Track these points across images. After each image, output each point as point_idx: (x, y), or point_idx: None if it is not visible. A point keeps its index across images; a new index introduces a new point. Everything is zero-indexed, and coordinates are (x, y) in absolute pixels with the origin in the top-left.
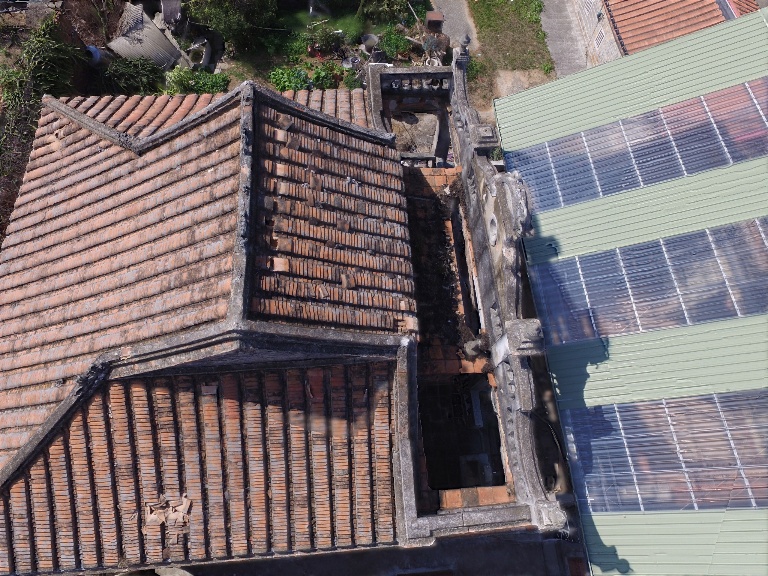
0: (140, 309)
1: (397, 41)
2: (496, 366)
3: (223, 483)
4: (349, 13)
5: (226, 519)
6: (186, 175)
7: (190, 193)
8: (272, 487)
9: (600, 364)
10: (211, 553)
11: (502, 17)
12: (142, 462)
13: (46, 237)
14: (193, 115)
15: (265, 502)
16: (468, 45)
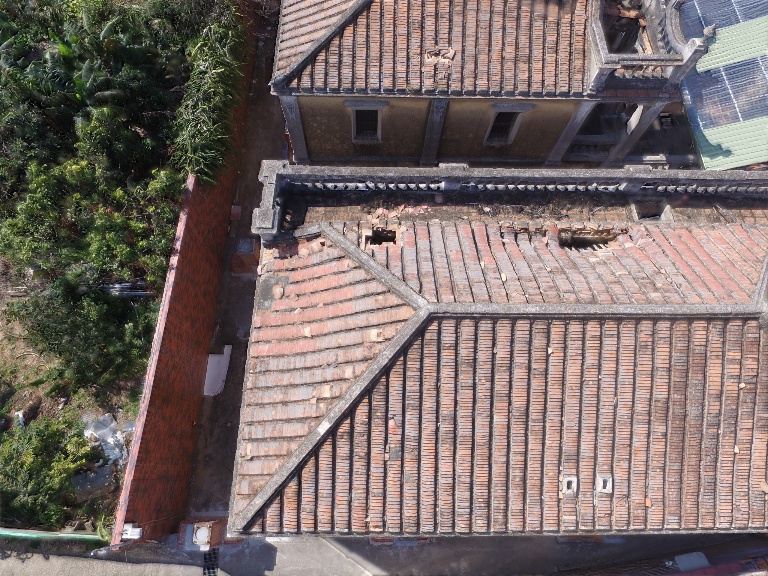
0: None
1: None
2: (648, 6)
3: (476, 42)
4: None
5: (475, 67)
6: None
7: None
8: (506, 48)
9: (709, 47)
10: (464, 89)
11: None
12: (428, 20)
13: None
14: None
15: (501, 58)
16: None
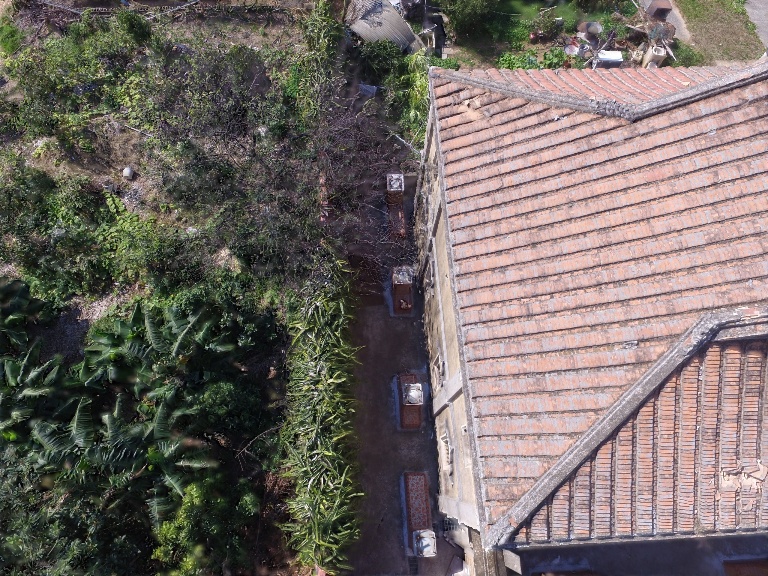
0: (737, 270)
1: (615, 29)
2: None
3: None
4: (560, 1)
5: None
6: (736, 139)
7: (750, 156)
8: None
9: None
10: None
11: (706, 8)
12: (727, 426)
13: (512, 204)
14: (726, 79)
15: None
16: (679, 35)
